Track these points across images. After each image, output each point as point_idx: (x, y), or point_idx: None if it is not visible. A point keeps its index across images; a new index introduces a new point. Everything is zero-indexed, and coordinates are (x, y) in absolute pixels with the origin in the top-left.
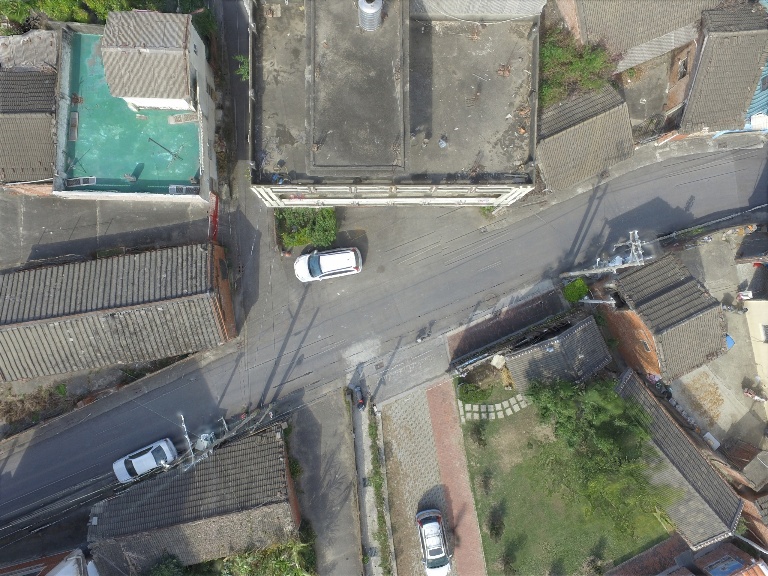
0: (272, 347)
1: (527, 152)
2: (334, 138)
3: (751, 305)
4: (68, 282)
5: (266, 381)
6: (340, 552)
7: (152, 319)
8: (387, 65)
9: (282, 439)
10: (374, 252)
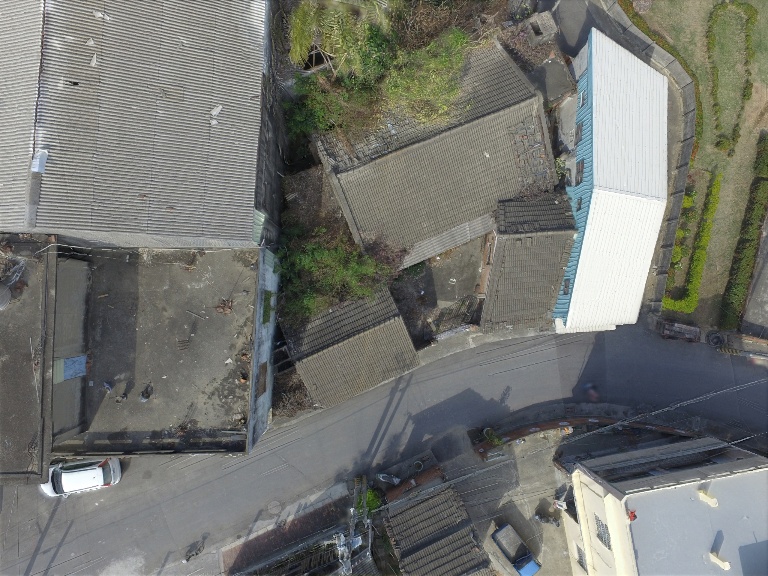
0: (16, 567)
1: None
2: None
3: (566, 516)
4: None
5: None
6: None
7: None
8: (25, 346)
9: None
10: None
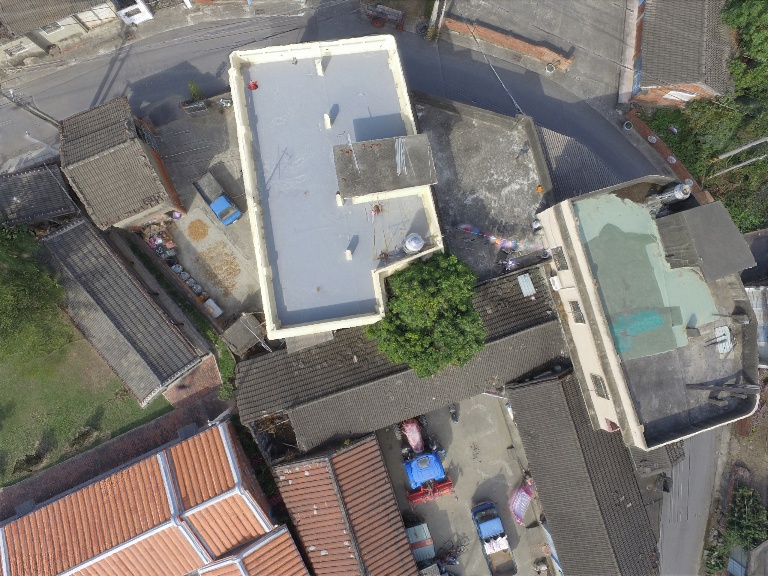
0: None
1: None
2: None
3: None
4: None
5: None
6: None
7: None
8: None
9: None
10: None
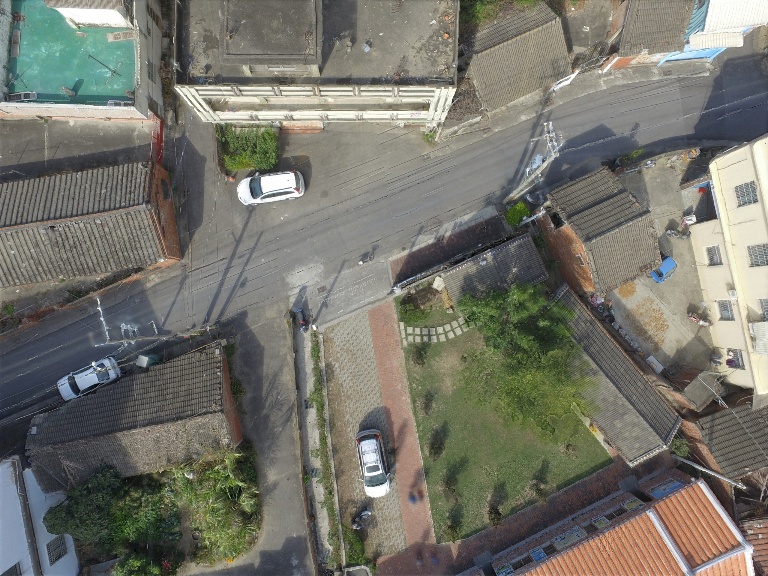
0: (216, 270)
1: (451, 57)
2: (247, 28)
3: (695, 229)
4: (11, 197)
5: (210, 303)
6: (281, 472)
7: (91, 232)
8: None
9: (221, 355)
10: (317, 177)
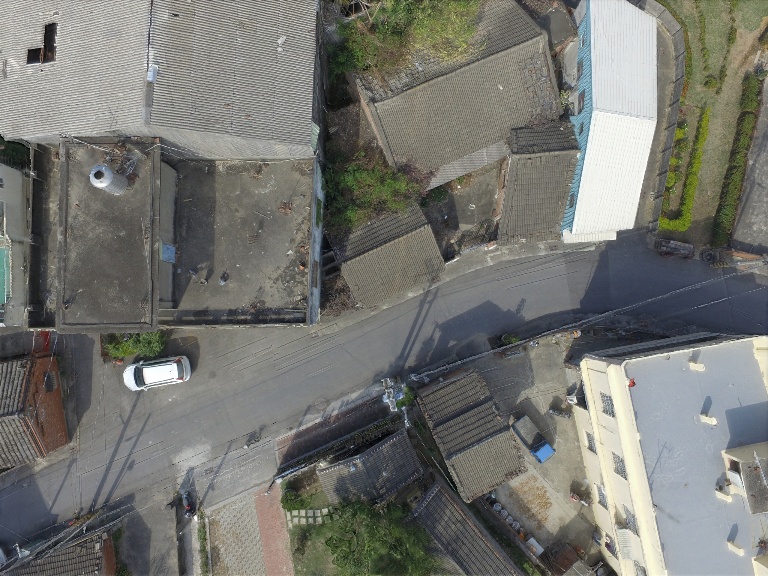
0: (103, 453)
1: None
2: (84, 297)
3: (577, 410)
4: None
5: (97, 487)
6: None
7: None
8: (137, 225)
9: (100, 550)
10: (205, 358)
